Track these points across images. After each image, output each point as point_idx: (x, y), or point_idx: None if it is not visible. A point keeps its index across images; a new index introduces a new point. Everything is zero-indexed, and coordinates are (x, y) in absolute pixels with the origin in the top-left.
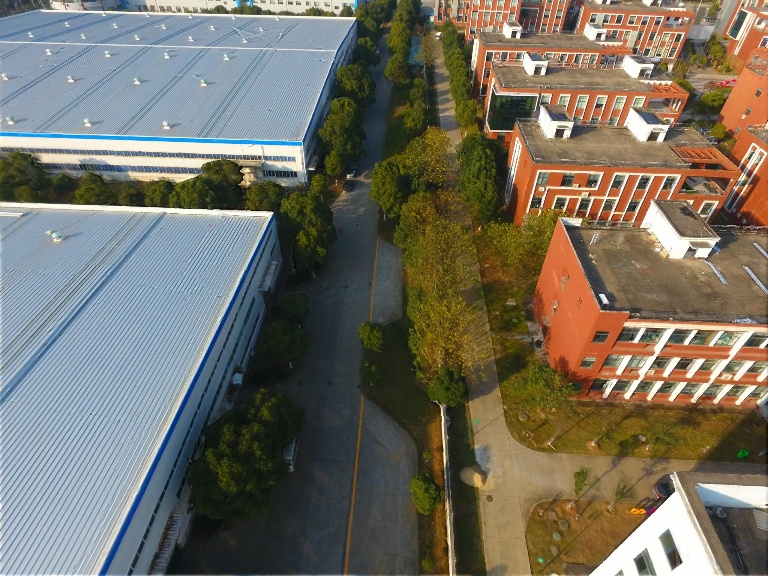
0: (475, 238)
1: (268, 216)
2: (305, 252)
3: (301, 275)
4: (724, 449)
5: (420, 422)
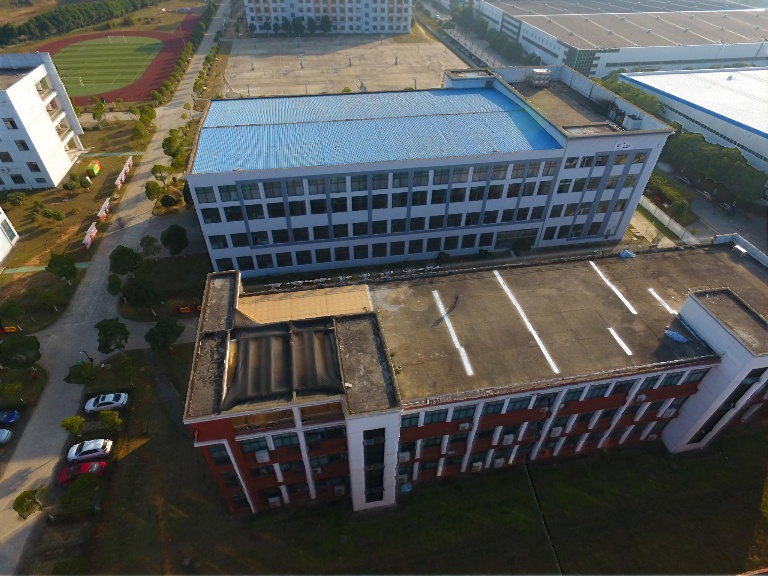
0: None
1: None
2: None
3: None
4: None
5: None
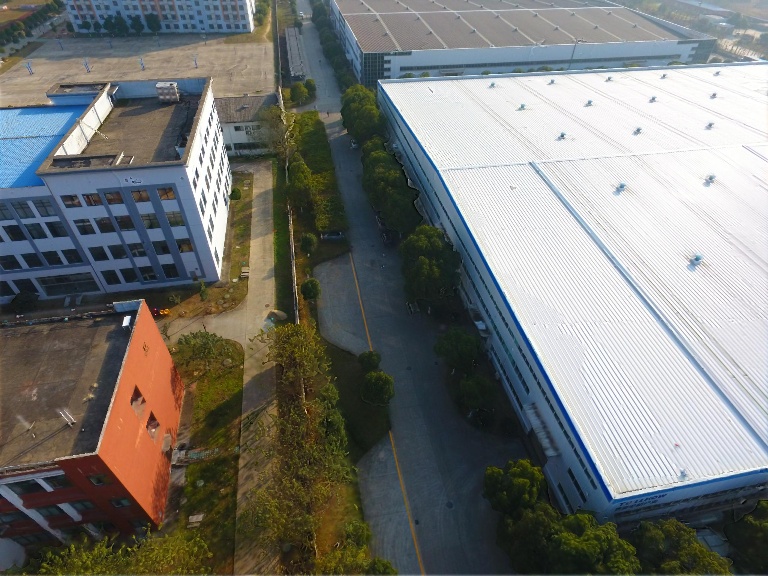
0: None
1: None
2: None
3: None
4: None
5: None
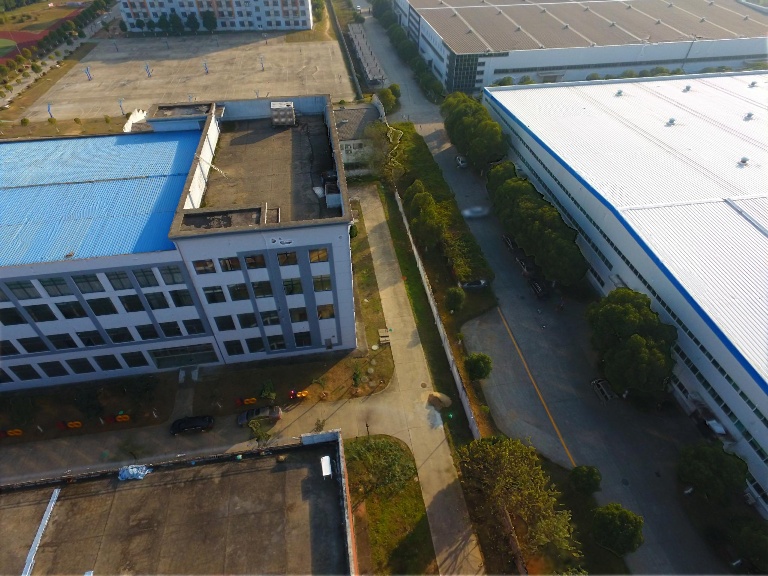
0: None
1: None
2: None
3: None
4: None
5: None
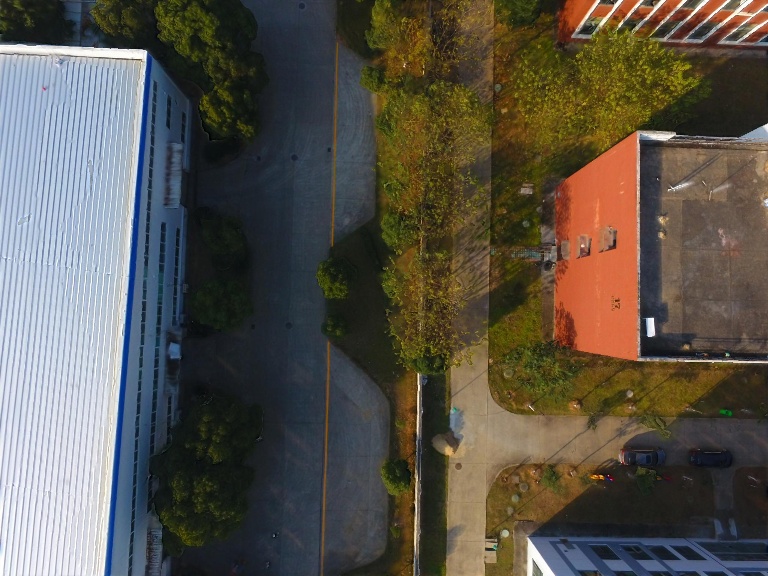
0: (494, 43)
1: (140, 58)
2: (220, 133)
3: (224, 143)
4: (709, 404)
5: (394, 378)
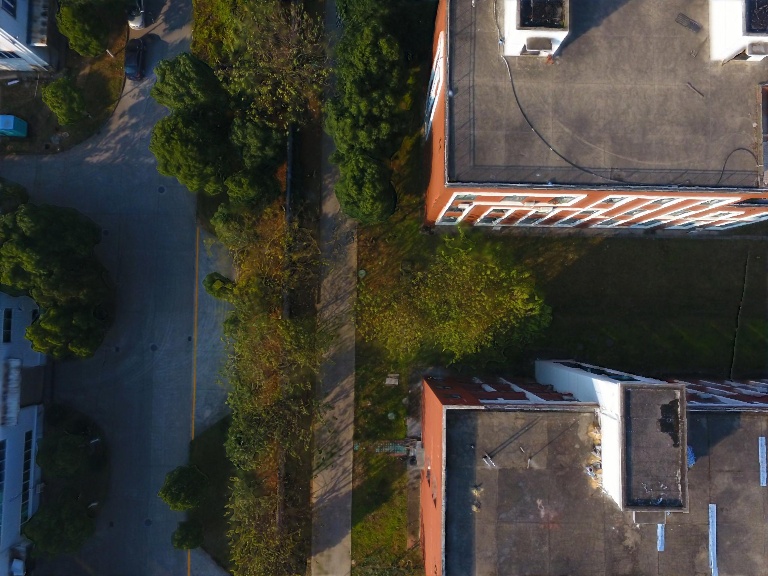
0: (358, 227)
1: None
2: None
3: None
4: None
5: None
